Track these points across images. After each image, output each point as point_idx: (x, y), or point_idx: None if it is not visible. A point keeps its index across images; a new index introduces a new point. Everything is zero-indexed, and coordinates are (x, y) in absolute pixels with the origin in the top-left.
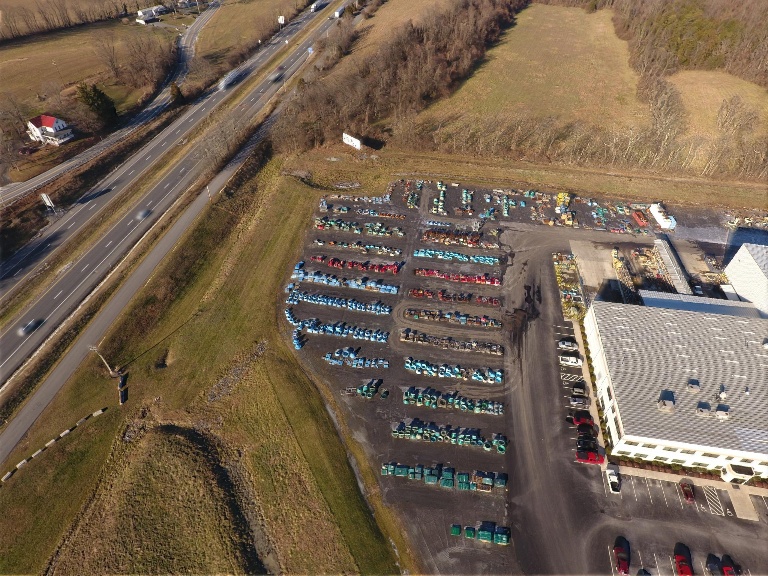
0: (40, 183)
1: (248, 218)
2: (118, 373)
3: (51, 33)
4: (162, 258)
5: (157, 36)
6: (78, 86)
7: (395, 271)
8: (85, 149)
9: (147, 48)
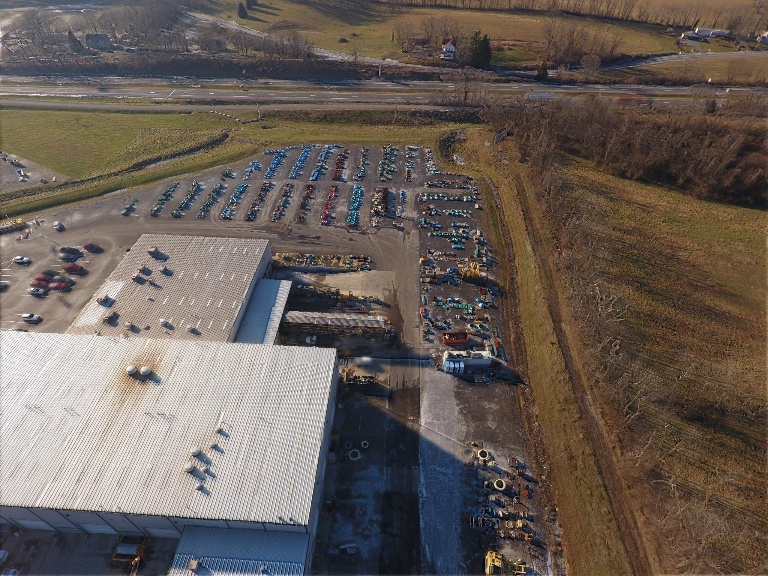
0: (397, 65)
1: (394, 128)
2: (261, 119)
3: (602, 18)
4: (339, 108)
5: (607, 33)
6: (477, 31)
7: (333, 177)
8: (445, 67)
9: (577, 36)
